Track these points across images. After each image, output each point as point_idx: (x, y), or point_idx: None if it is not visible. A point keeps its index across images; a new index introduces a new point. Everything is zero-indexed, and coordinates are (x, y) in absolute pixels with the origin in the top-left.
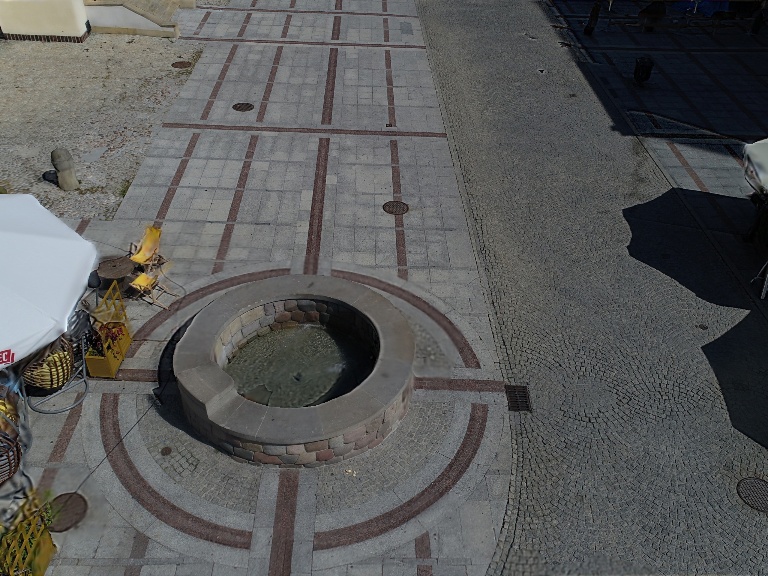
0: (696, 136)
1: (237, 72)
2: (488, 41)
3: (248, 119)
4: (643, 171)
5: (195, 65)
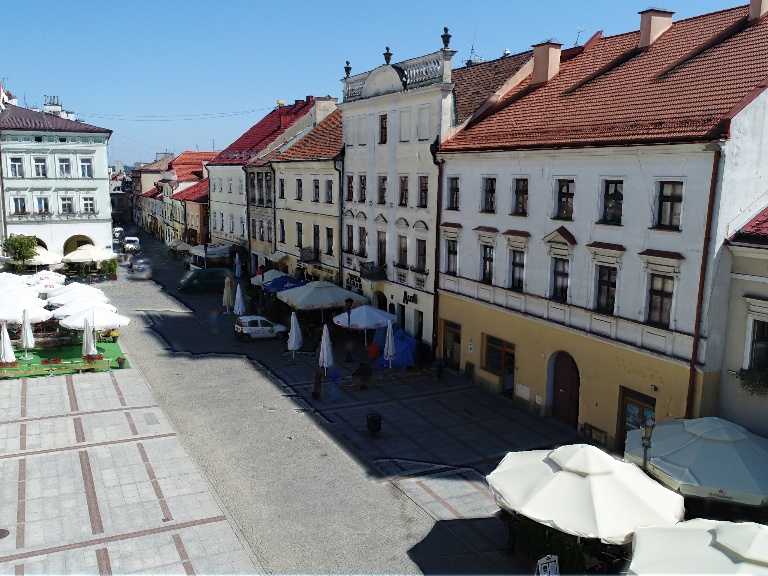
0: (435, 471)
1: None
2: (233, 418)
3: (6, 548)
4: (408, 512)
5: None
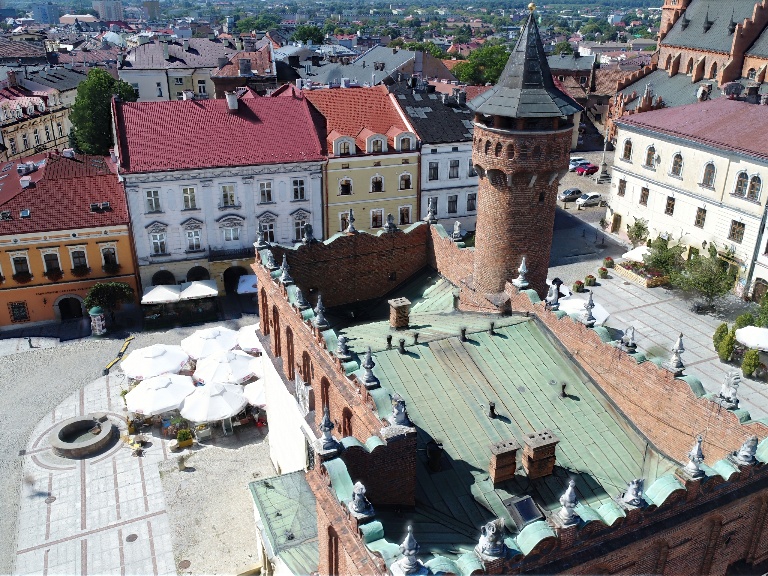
0: None
1: (147, 569)
2: None
3: (127, 529)
4: None
5: (176, 567)
